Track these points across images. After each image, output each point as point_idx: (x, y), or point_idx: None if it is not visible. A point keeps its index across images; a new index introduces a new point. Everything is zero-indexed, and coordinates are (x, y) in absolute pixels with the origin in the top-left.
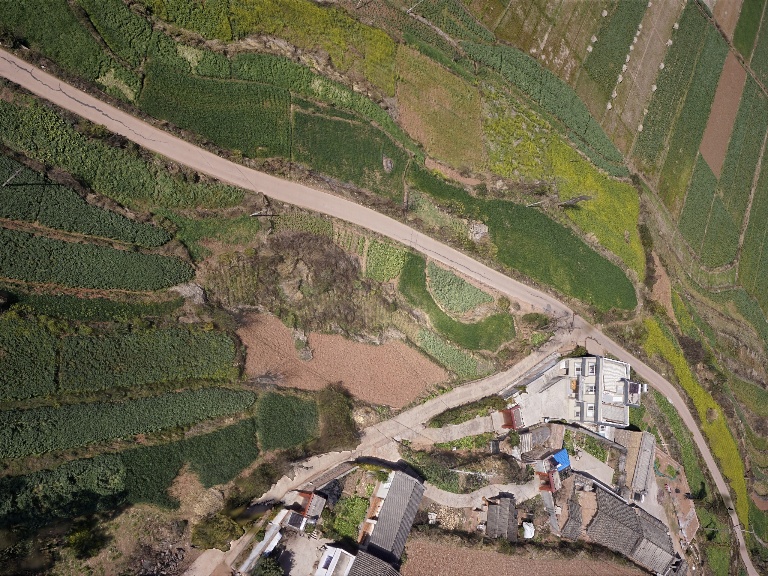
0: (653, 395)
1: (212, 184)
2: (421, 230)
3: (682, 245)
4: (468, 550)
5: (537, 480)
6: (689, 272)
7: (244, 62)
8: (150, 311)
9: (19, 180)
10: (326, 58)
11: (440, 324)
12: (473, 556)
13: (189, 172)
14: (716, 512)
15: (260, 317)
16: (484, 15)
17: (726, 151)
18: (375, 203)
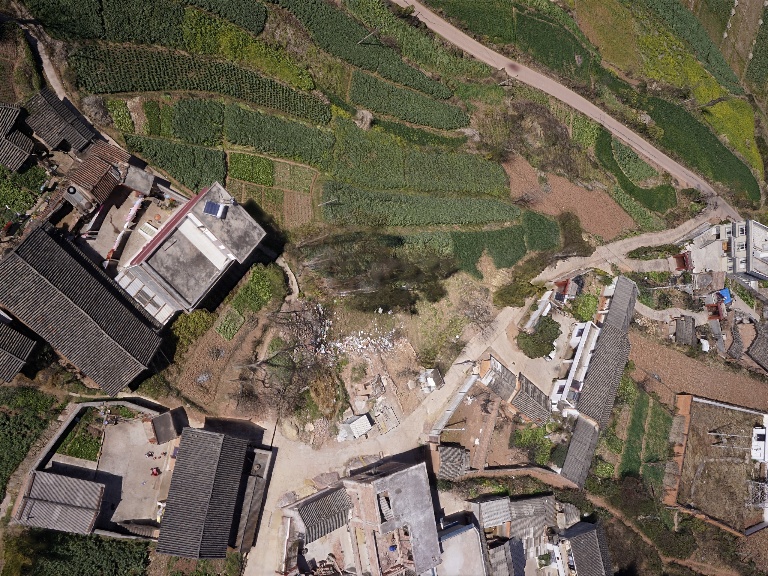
0: None
1: (471, 60)
2: (607, 112)
3: None
4: (666, 348)
5: (706, 312)
6: None
7: None
8: (448, 143)
9: (367, 40)
10: None
11: (625, 186)
12: (670, 354)
13: (457, 49)
14: None
15: (515, 157)
16: None
17: None
18: (575, 86)
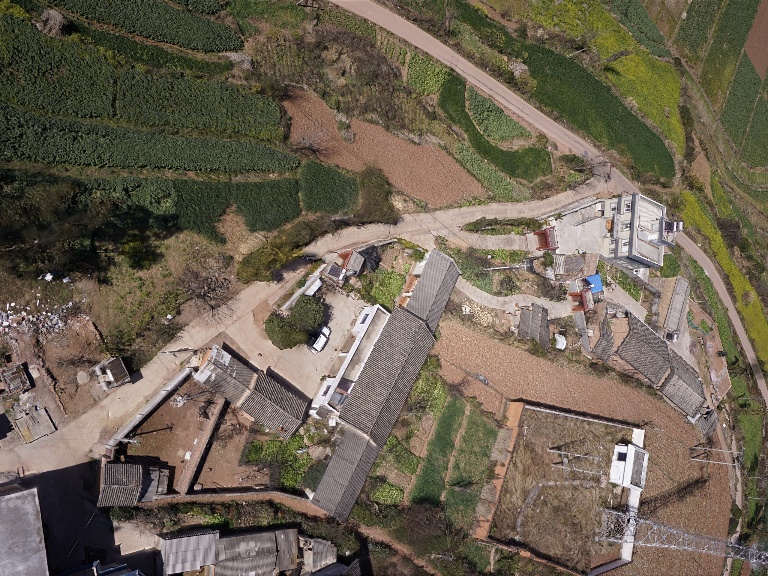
0: (689, 261)
1: None
2: (462, 54)
3: (723, 138)
4: (500, 344)
5: (570, 301)
6: (729, 166)
7: None
8: (201, 68)
9: None
10: None
11: (478, 144)
12: (505, 350)
13: None
14: (749, 390)
15: (305, 94)
16: None
17: None
18: (417, 19)
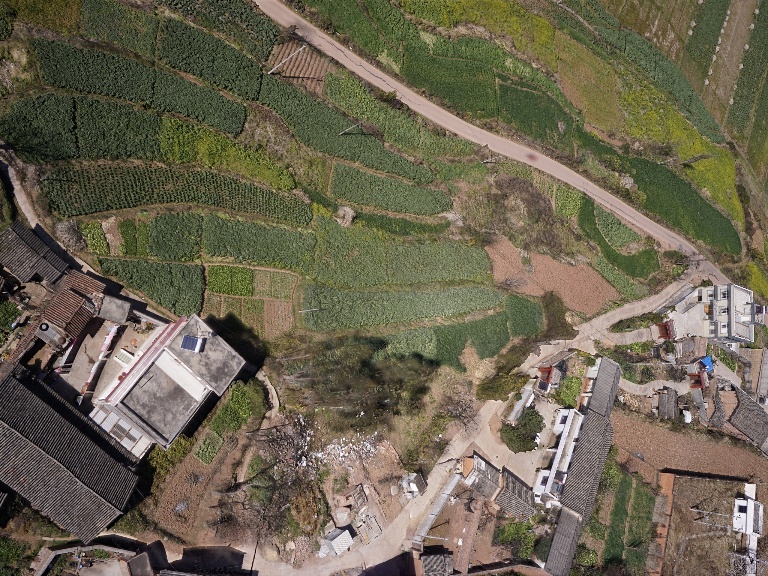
0: (760, 326)
1: (454, 138)
2: (590, 179)
3: (767, 205)
4: (649, 425)
5: (688, 380)
6: None
7: (462, 44)
8: (431, 230)
9: (348, 130)
10: (511, 41)
11: (608, 254)
12: (652, 430)
13: (439, 128)
14: None
15: (498, 239)
16: (610, 5)
17: None
18: (559, 156)
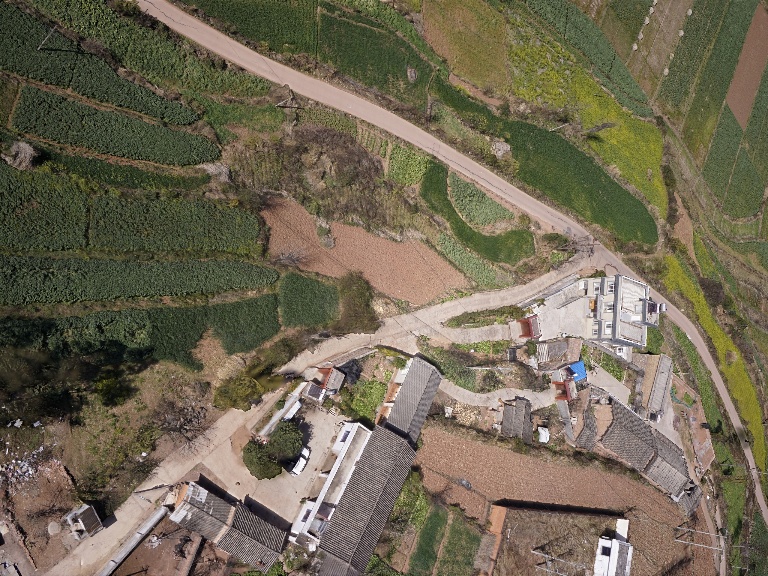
0: (672, 328)
1: (239, 73)
2: (444, 140)
3: (705, 192)
4: (483, 445)
5: (553, 390)
6: (712, 220)
7: None
8: (177, 184)
9: (53, 45)
10: None
11: (460, 232)
12: (488, 451)
13: (217, 59)
14: (732, 452)
15: (284, 202)
16: None
17: (753, 103)
18: (399, 108)
